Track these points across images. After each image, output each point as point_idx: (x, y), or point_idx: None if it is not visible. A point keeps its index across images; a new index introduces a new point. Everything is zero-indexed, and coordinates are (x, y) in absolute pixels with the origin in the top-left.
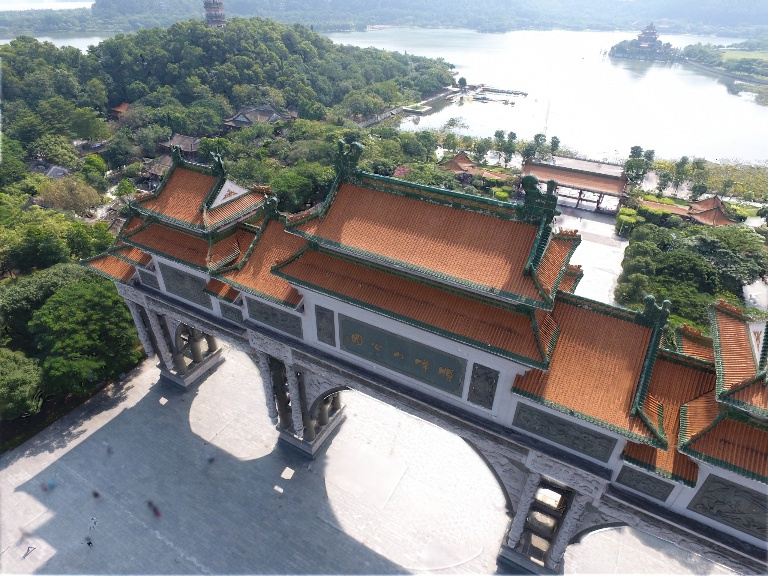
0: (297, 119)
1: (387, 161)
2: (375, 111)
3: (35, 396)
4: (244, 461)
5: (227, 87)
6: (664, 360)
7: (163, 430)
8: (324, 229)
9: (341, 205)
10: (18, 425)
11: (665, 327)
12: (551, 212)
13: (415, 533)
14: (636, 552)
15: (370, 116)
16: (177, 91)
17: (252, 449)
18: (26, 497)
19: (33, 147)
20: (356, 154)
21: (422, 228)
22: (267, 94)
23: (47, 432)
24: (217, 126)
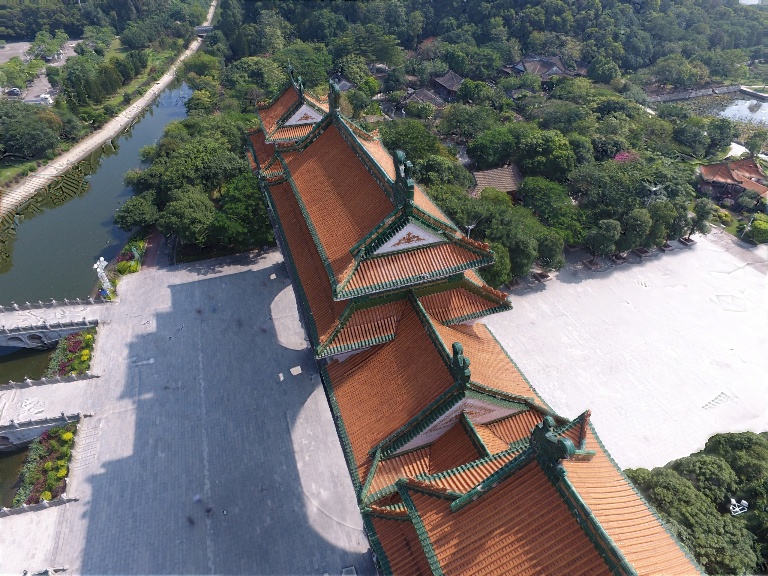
0: (579, 77)
1: (623, 142)
2: (688, 84)
3: (204, 234)
4: (280, 344)
5: (527, 32)
6: (466, 433)
7: (257, 295)
8: (295, 161)
9: (318, 144)
10: (196, 250)
11: (562, 418)
12: (406, 201)
13: (334, 475)
14: None
15: (682, 89)
16: (479, 31)
17: (291, 340)
18: (169, 293)
19: (338, 63)
20: (334, 96)
21: (339, 183)
22: (566, 45)
23: (205, 262)
24: (496, 71)
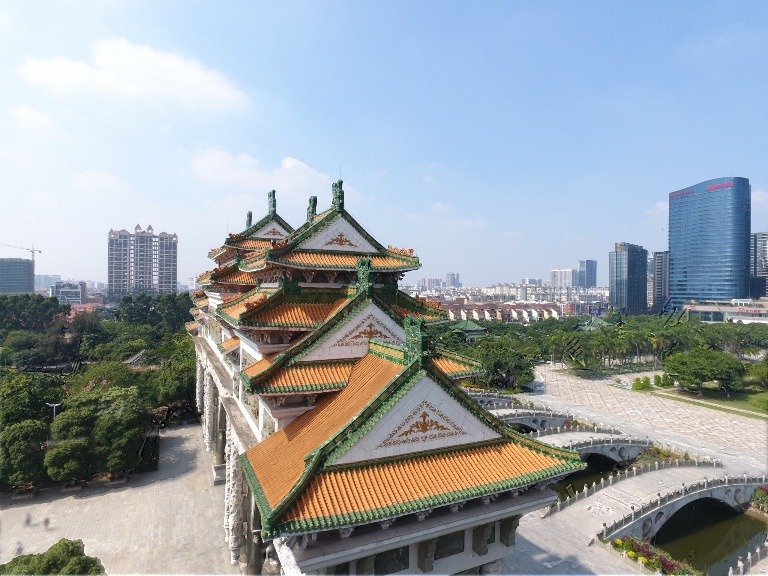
0: None
1: None
2: None
3: None
4: None
5: None
6: None
7: None
8: None
9: None
10: None
11: None
12: None
13: None
14: (205, 456)
15: None
16: None
17: None
18: None
19: None
20: None
21: None
22: None
23: None
24: None
